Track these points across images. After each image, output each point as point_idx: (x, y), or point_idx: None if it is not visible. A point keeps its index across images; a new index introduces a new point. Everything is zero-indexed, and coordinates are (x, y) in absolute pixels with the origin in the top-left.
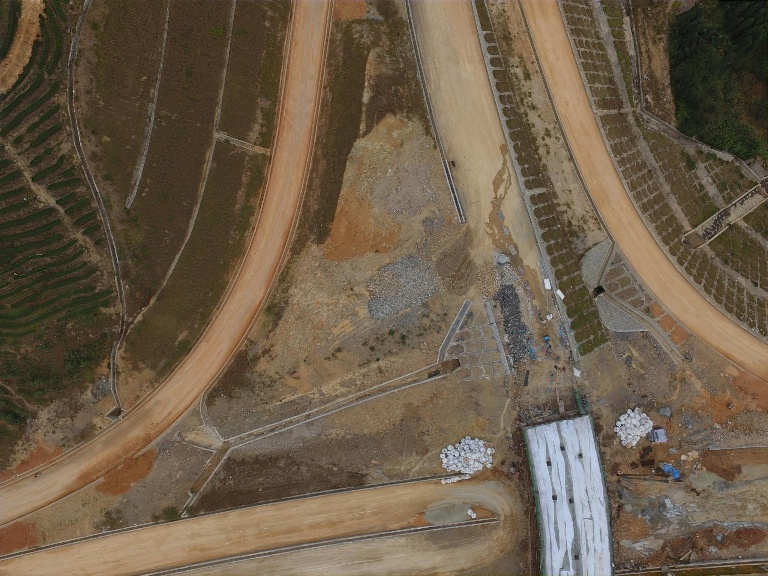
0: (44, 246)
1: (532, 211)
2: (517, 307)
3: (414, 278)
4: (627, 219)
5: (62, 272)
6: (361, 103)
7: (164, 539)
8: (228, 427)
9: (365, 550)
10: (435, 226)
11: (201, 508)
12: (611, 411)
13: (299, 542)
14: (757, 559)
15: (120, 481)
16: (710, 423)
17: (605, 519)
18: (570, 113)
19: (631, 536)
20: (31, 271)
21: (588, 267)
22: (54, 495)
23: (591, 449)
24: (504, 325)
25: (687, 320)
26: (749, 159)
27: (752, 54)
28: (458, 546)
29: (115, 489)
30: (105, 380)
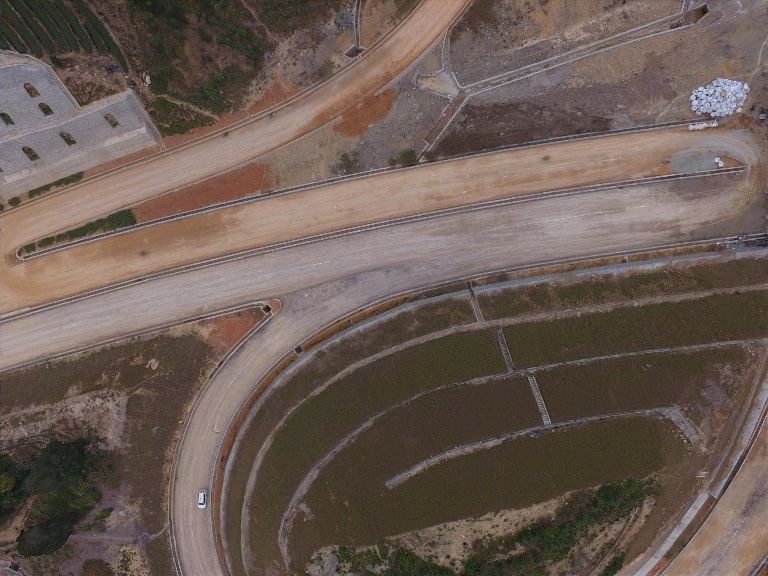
0: None
1: None
2: None
3: None
4: None
5: None
6: None
7: (400, 186)
8: (468, 71)
9: (607, 200)
10: None
11: (441, 151)
12: None
13: (539, 191)
14: None
15: (359, 120)
16: None
17: None
18: None
19: None
20: None
21: None
22: (289, 136)
23: None
24: None
25: None
26: None
27: None
28: (702, 197)
29: (354, 128)
30: (349, 9)
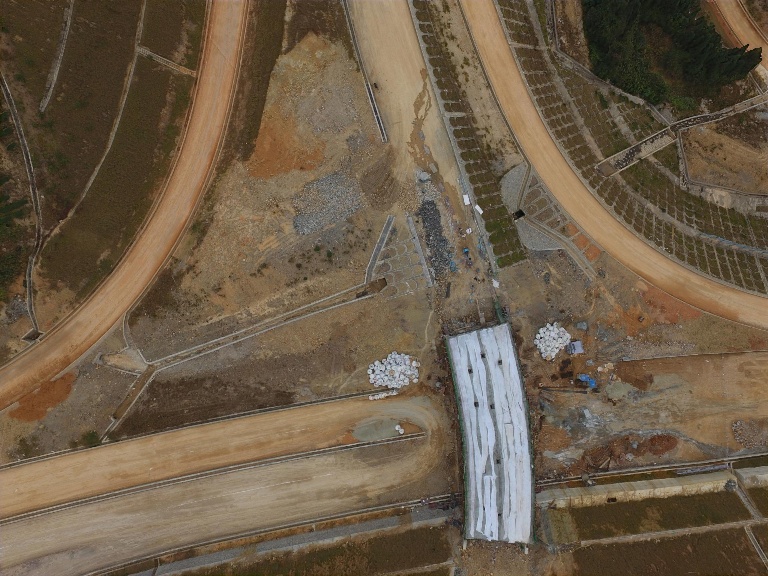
0: None
1: (451, 131)
2: (438, 222)
3: (338, 194)
4: (542, 144)
5: None
6: (283, 21)
7: (84, 466)
8: (152, 349)
9: (294, 470)
10: (358, 144)
11: (123, 432)
12: (530, 322)
13: (226, 464)
14: (670, 465)
15: (36, 405)
16: (623, 336)
17: (524, 423)
18: (487, 44)
19: (553, 447)
20: None
21: (507, 190)
22: None
23: (510, 356)
24: (426, 239)
25: (599, 239)
26: (659, 105)
27: (658, 8)
28: (387, 463)
29: (31, 414)
30: (21, 300)
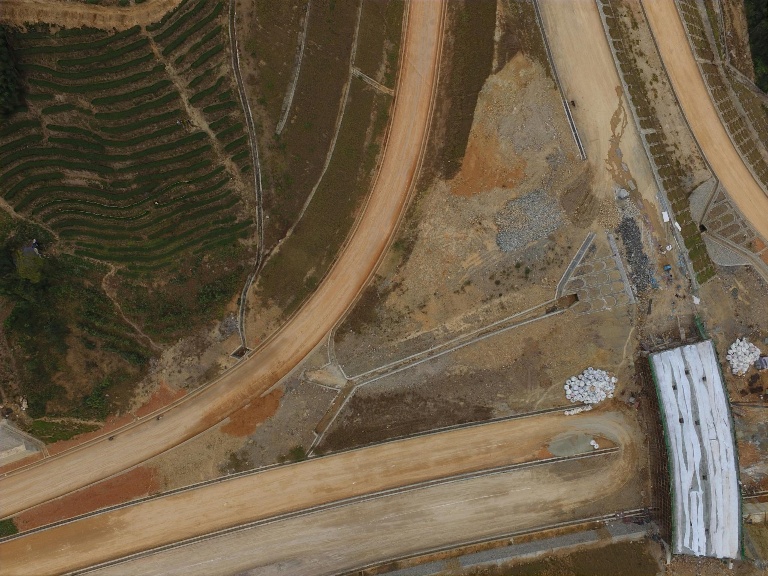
0: (191, 172)
1: (648, 148)
2: (638, 239)
3: (540, 212)
4: (729, 160)
5: (205, 201)
6: (493, 41)
7: (290, 480)
8: (354, 365)
9: (491, 484)
10: (558, 162)
11: (329, 447)
12: (726, 338)
13: (426, 479)
14: None
15: (247, 421)
16: None
17: (730, 439)
18: (674, 60)
19: (743, 462)
20: (172, 200)
21: (694, 205)
22: (177, 438)
23: (714, 372)
24: (626, 256)
25: None
26: None
27: None
28: (581, 477)
29: (242, 429)
30: (233, 317)
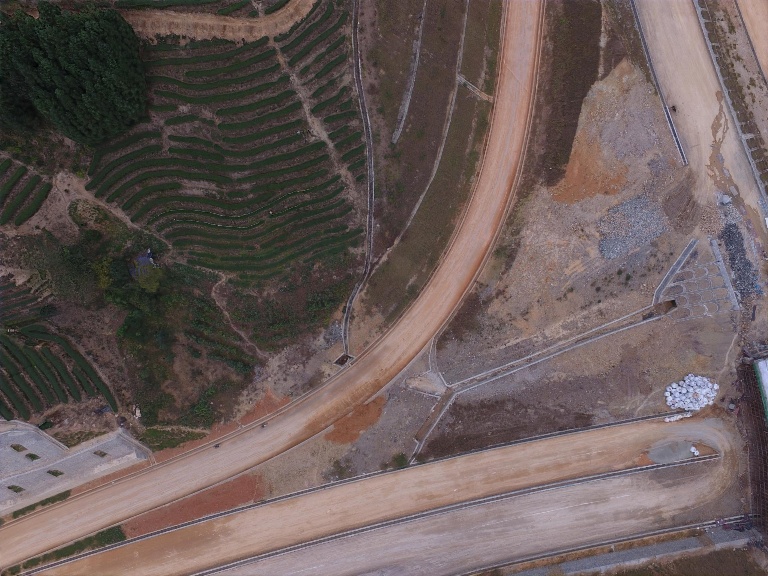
0: (307, 182)
1: (749, 154)
2: (741, 245)
3: (643, 218)
4: None
5: (318, 210)
6: (598, 47)
7: (392, 488)
8: (454, 372)
9: (592, 491)
10: (660, 168)
11: (431, 454)
12: None
13: (527, 486)
14: None
15: (351, 428)
16: None
17: None
18: None
19: None
20: (286, 209)
21: None
22: (281, 445)
23: None
24: (730, 262)
25: None
26: None
27: None
28: (681, 484)
29: (346, 437)
30: (338, 325)
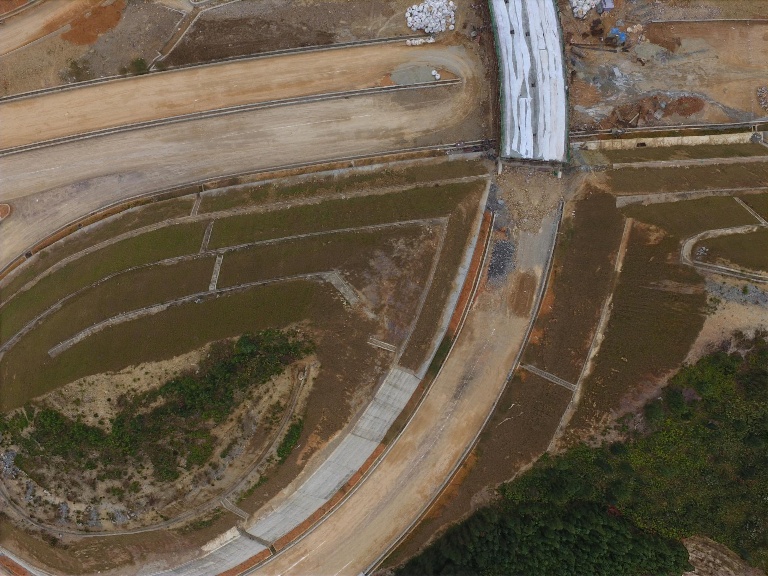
0: None
1: None
2: None
3: None
4: None
5: None
6: None
7: (132, 94)
8: None
9: (334, 109)
10: None
11: (170, 60)
12: None
13: (268, 100)
14: (697, 124)
15: (87, 29)
16: None
17: (559, 49)
18: None
19: (584, 102)
20: None
21: None
22: (18, 44)
23: None
24: None
25: None
26: None
27: None
28: (423, 107)
29: (82, 36)
30: None
